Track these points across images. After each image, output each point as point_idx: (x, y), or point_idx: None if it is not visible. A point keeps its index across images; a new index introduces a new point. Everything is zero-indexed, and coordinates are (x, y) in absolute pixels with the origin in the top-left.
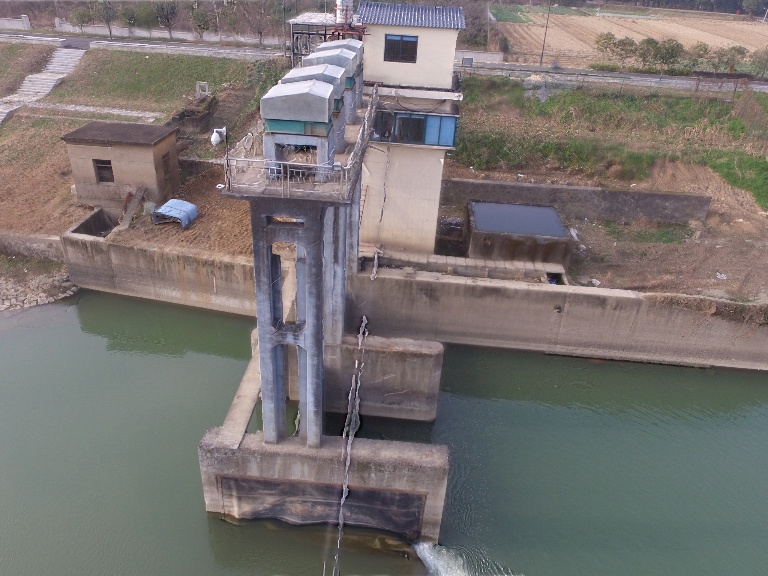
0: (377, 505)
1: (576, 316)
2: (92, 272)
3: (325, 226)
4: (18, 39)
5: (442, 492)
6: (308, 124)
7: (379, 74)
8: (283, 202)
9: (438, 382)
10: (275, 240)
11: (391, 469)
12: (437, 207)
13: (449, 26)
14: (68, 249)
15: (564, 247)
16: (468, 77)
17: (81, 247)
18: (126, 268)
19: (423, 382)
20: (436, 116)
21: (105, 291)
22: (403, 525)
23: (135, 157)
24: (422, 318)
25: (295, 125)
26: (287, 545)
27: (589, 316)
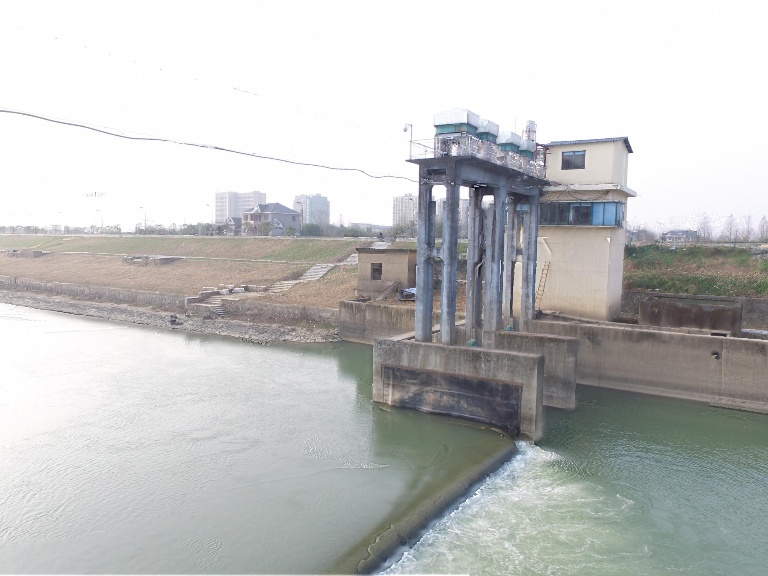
0: (486, 396)
1: (736, 364)
2: (353, 327)
3: (487, 234)
4: (354, 238)
5: (534, 384)
6: (457, 126)
7: (558, 179)
8: (436, 160)
9: (573, 370)
10: (430, 184)
11: (496, 359)
12: (607, 278)
13: (608, 140)
14: (342, 310)
15: (731, 314)
16: (693, 247)
17: (350, 308)
18: (374, 322)
19: (559, 367)
20: (600, 203)
21: (358, 342)
22: (505, 417)
23: (397, 260)
24: (586, 362)
25: (451, 128)
26: (421, 436)
27: (750, 364)
